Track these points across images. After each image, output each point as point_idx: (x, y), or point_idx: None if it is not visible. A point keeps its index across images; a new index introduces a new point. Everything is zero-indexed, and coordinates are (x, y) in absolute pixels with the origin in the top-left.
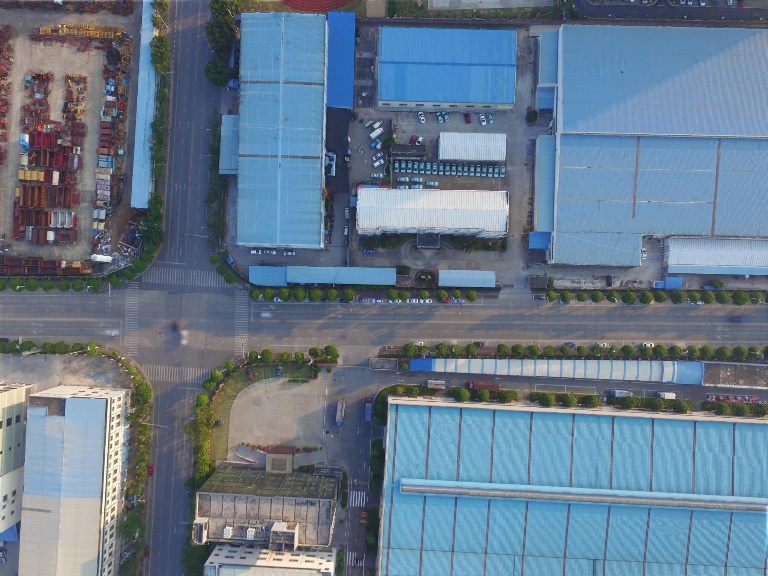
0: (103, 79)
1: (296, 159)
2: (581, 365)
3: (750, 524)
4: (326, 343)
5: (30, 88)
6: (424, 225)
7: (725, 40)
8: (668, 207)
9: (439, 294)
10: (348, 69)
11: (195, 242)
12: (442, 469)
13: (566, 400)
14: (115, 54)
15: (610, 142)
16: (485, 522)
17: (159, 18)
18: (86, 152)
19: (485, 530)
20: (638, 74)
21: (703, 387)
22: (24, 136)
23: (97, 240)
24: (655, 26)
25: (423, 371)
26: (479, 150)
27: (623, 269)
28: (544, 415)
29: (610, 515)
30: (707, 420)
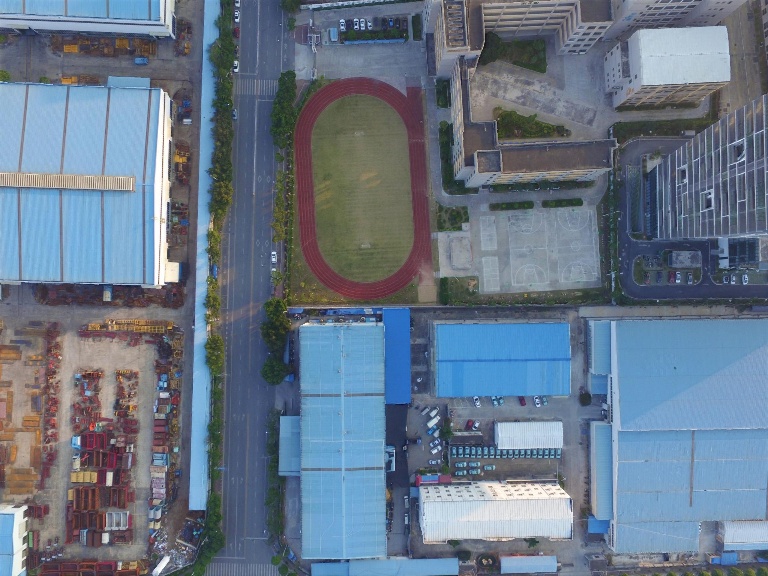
0: (155, 374)
1: (360, 471)
2: None
3: None
4: None
5: (80, 386)
6: (490, 535)
7: None
8: (724, 495)
9: None
10: (405, 365)
11: (254, 536)
12: None
13: None
14: (167, 349)
15: (666, 436)
16: None
17: (212, 316)
18: (139, 448)
19: None
20: (690, 369)
21: None
22: (76, 440)
23: (153, 539)
24: (704, 320)
25: None
26: (537, 440)
27: None
28: None
29: None
30: None
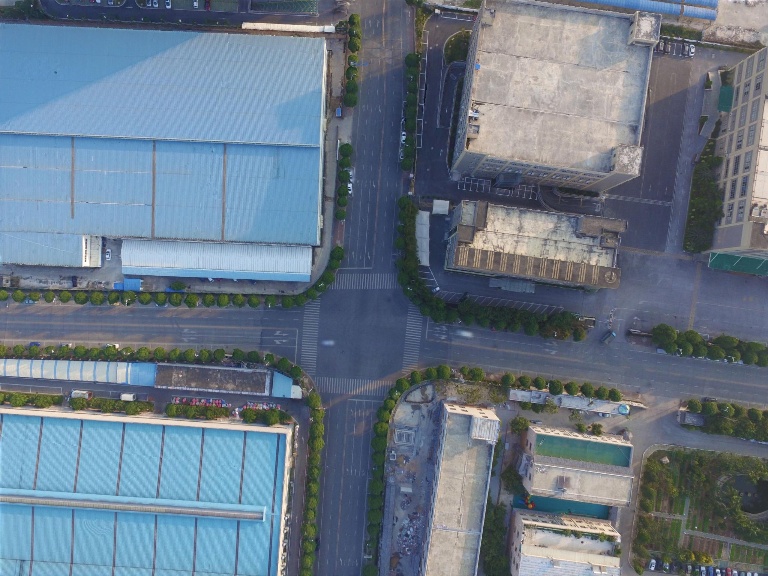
0: None
1: None
2: (38, 365)
3: (176, 527)
4: None
5: None
6: None
7: (163, 43)
8: (106, 208)
9: None
10: None
11: None
12: None
13: None
14: None
15: (45, 142)
16: None
17: None
18: None
19: None
20: (72, 75)
21: (159, 389)
22: None
23: None
24: None
25: None
26: None
27: (90, 270)
28: None
29: (34, 516)
30: (132, 422)
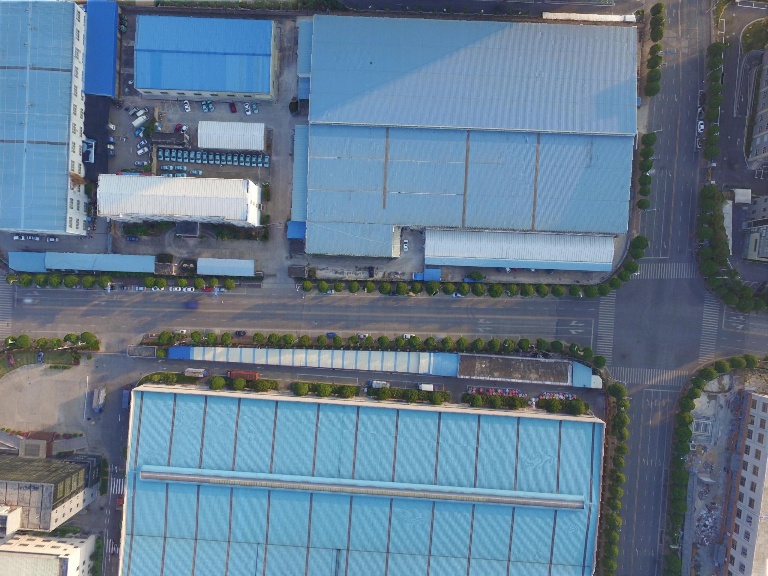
0: None
1: (42, 145)
2: (339, 355)
3: (492, 516)
4: (89, 330)
5: None
6: (165, 212)
7: (476, 33)
8: (418, 198)
9: (194, 282)
10: (107, 57)
11: None
12: (191, 457)
13: (318, 390)
14: None
15: (359, 133)
16: (228, 510)
17: None
18: None
19: (228, 518)
20: (387, 65)
21: (460, 379)
22: None
23: None
24: (406, 18)
25: (183, 359)
26: (236, 139)
27: (386, 260)
28: (289, 404)
29: (352, 505)
30: (450, 411)
